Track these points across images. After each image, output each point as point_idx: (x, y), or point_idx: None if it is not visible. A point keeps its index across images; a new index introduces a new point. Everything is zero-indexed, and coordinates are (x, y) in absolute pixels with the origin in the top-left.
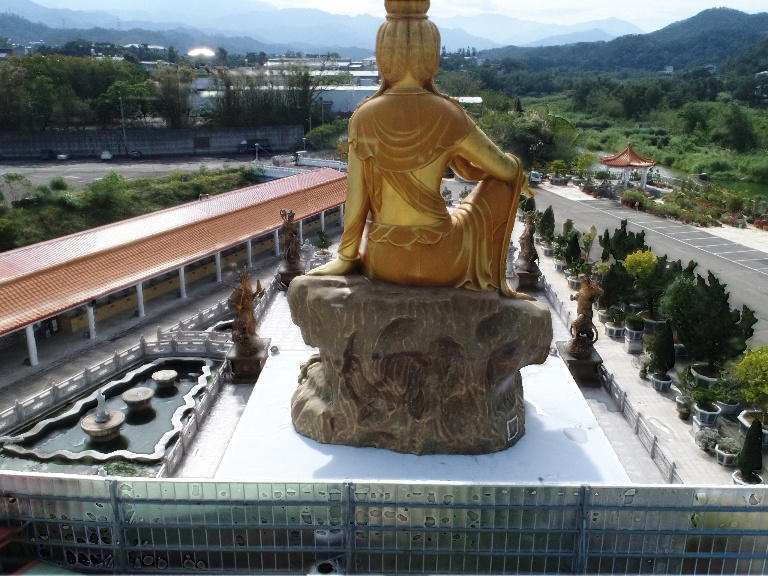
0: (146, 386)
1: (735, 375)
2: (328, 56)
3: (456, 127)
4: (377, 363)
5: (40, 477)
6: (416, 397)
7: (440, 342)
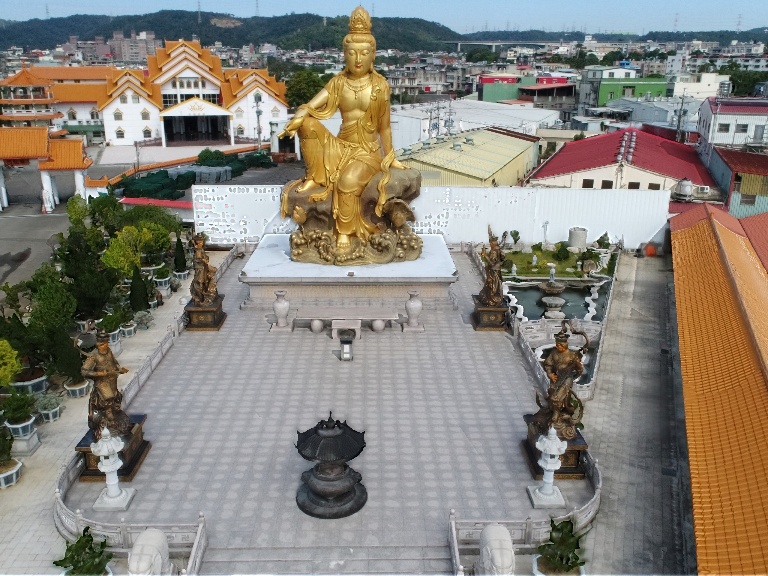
0: None
1: None
2: None
3: None
4: None
5: None
6: None
7: None
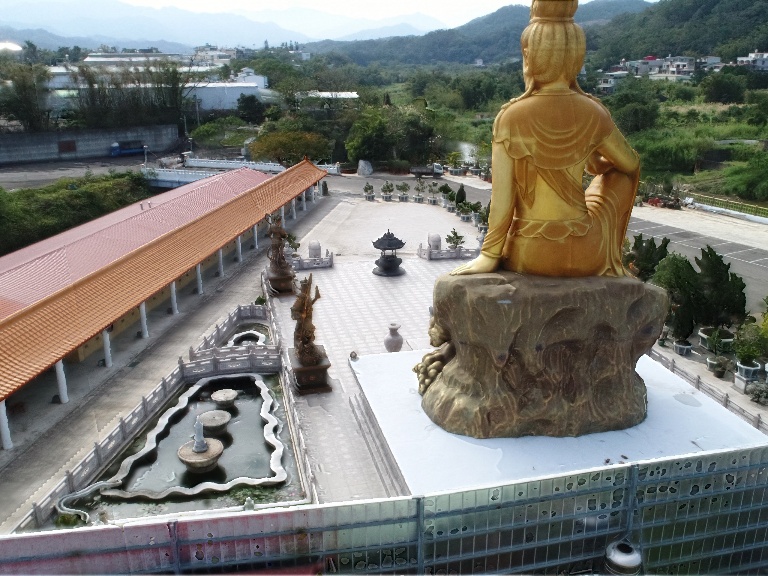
0: (200, 409)
1: (753, 334)
2: (196, 52)
3: (604, 125)
4: (540, 354)
5: (341, 507)
6: (568, 382)
7: (597, 328)
